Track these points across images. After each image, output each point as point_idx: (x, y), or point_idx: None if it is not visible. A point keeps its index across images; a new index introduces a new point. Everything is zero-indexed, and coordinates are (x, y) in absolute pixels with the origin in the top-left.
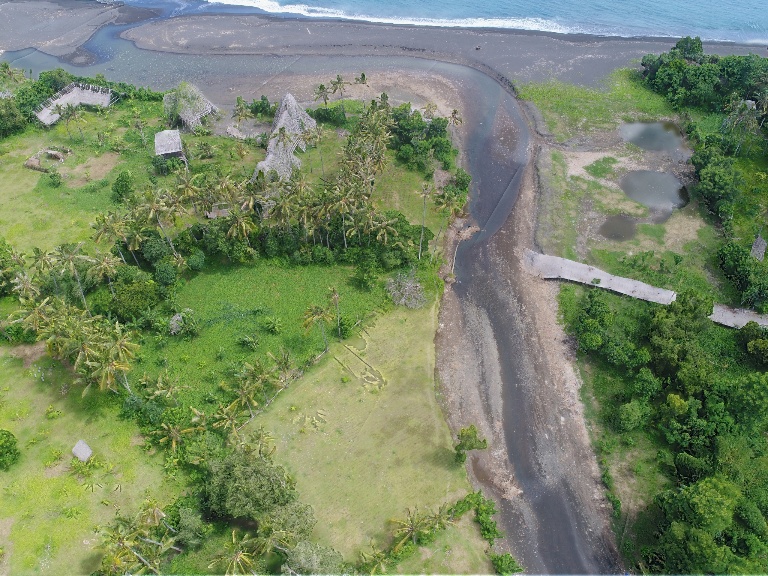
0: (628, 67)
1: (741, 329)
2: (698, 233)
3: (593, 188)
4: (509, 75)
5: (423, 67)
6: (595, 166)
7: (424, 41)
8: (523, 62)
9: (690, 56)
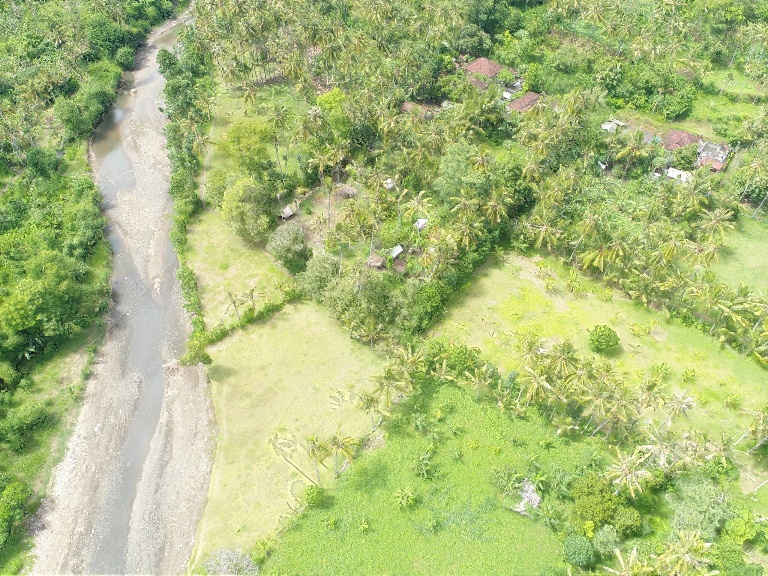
0: None
1: None
2: None
3: None
4: None
5: None
6: None
7: None
8: None
9: None
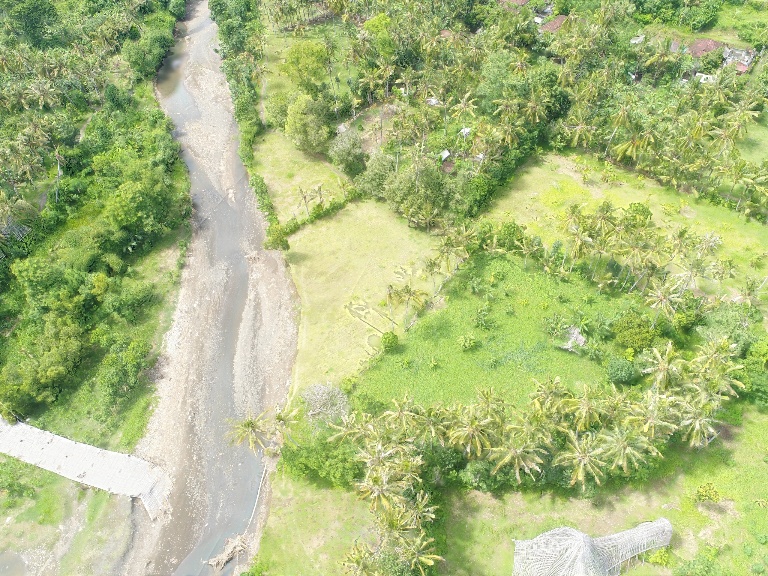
0: None
1: None
2: None
3: None
4: None
5: None
6: None
7: None
8: None
9: None
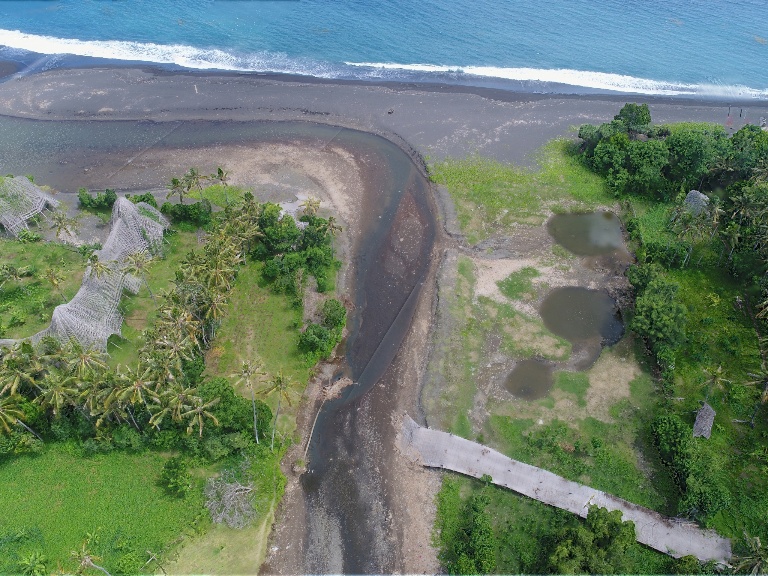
0: (564, 137)
1: (673, 567)
2: (630, 387)
3: (504, 316)
4: (422, 149)
5: (324, 137)
6: (510, 281)
7: (329, 102)
8: (441, 131)
9: (635, 128)
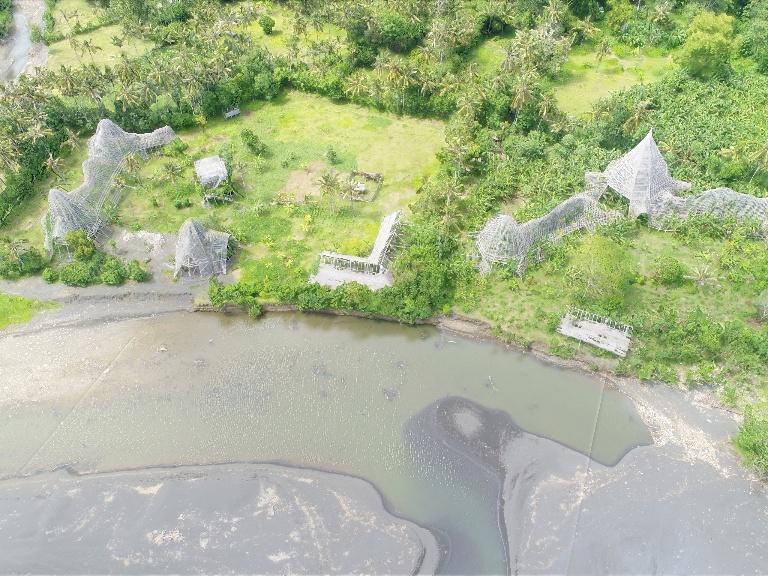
0: None
1: None
2: None
3: None
4: None
5: None
6: None
7: None
8: None
9: None
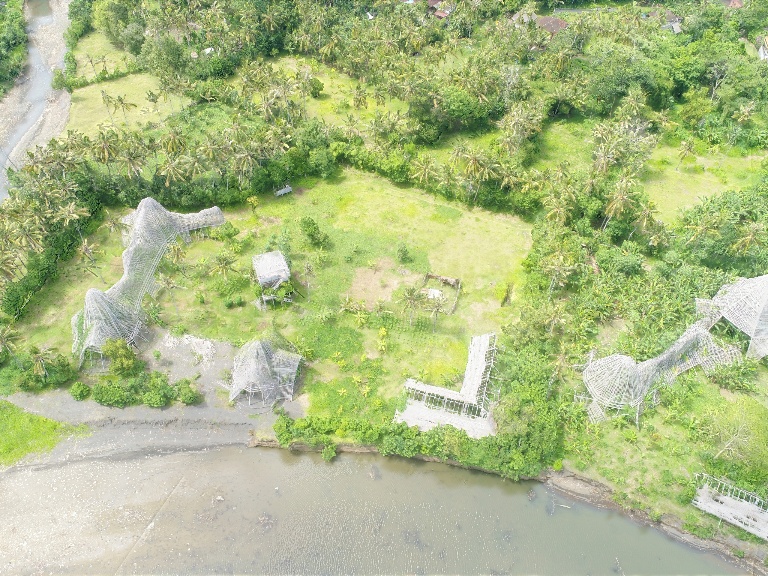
0: None
1: None
2: None
3: None
4: None
5: None
6: None
7: None
8: None
9: None
